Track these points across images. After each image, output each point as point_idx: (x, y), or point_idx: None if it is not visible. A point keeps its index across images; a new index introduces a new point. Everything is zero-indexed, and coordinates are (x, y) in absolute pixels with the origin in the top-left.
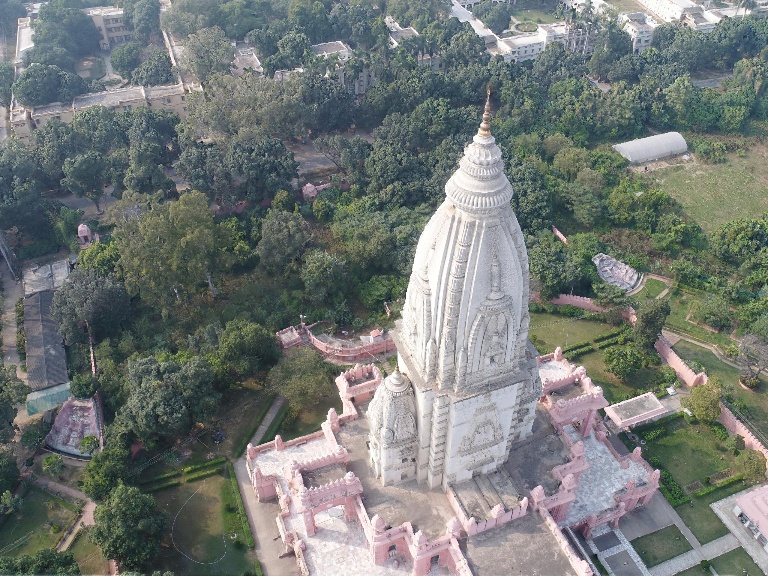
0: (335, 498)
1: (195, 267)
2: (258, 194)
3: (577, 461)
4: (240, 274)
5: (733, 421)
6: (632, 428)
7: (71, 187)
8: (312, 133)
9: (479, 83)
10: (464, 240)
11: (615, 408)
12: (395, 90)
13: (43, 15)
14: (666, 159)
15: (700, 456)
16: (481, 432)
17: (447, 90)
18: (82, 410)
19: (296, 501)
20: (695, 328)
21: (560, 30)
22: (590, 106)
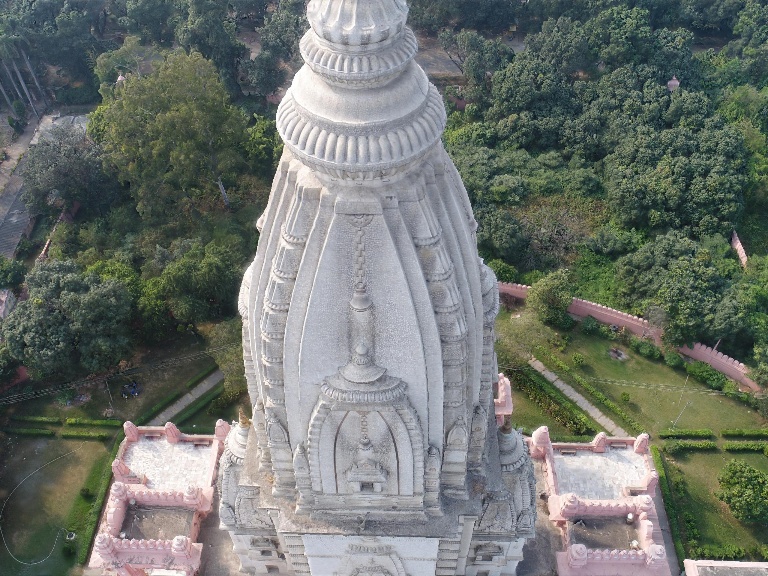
0: None
1: None
2: None
3: None
4: None
5: None
6: None
7: (130, 29)
8: (454, 27)
9: (710, 0)
10: (290, 228)
11: (703, 568)
12: None
13: None
14: None
15: None
16: None
17: (658, 2)
18: None
19: None
20: None
21: None
22: None
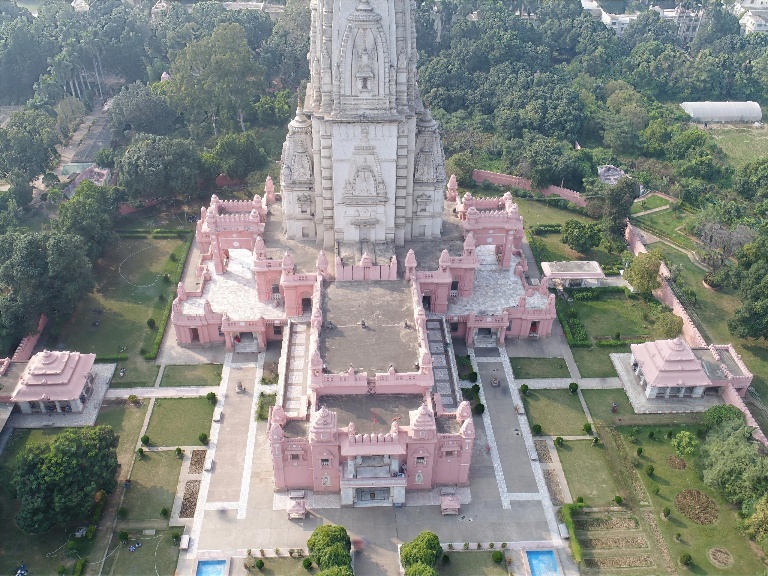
0: (241, 236)
1: (222, 89)
2: None
3: (467, 256)
4: None
5: (671, 299)
6: (564, 286)
7: (169, 47)
8: None
9: (561, 34)
10: None
11: (551, 263)
12: (476, 26)
13: None
14: (734, 123)
15: (623, 321)
16: (362, 178)
17: (527, 35)
18: (99, 176)
19: (205, 225)
20: (681, 237)
21: (671, 14)
22: (666, 65)
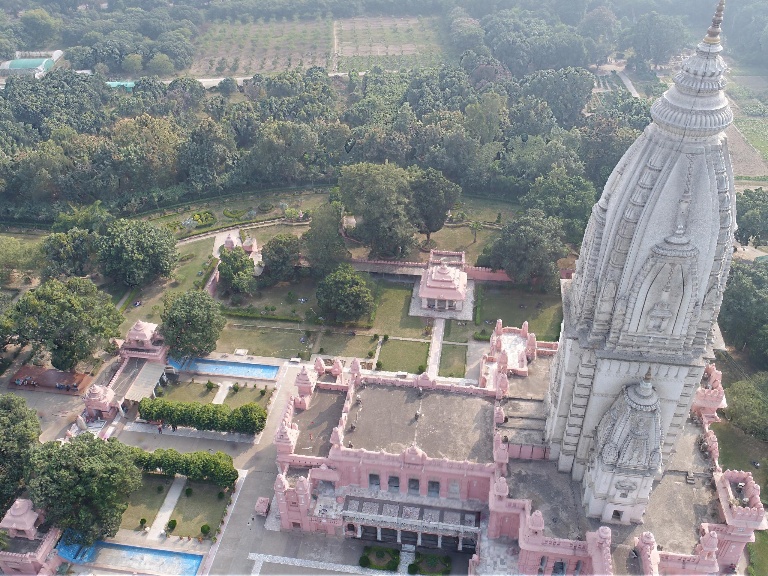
0: None
1: None
2: None
3: None
4: None
5: None
6: None
7: None
8: None
9: None
10: None
11: None
12: None
13: None
14: None
15: None
16: None
17: None
18: None
19: None
20: None
21: None
22: None
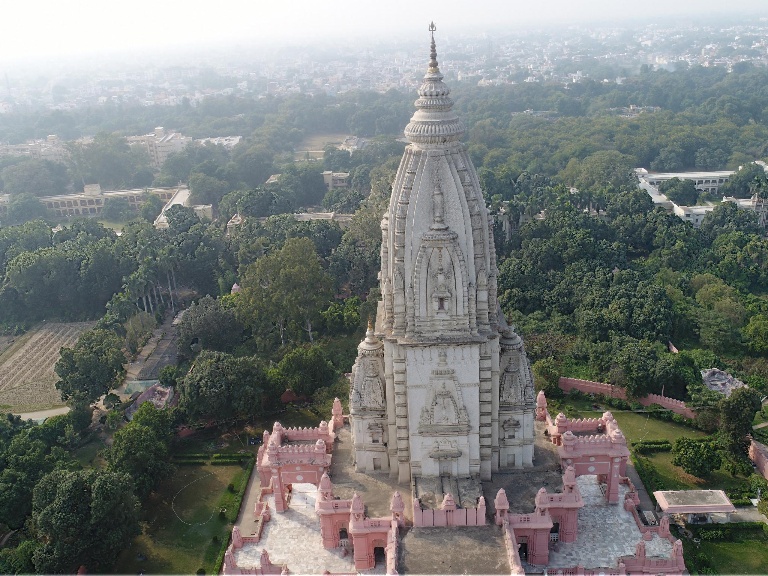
0: (305, 469)
1: (290, 301)
2: None
3: (567, 493)
4: None
5: None
6: (686, 522)
7: (241, 260)
8: None
9: (635, 229)
10: (410, 167)
11: (666, 493)
12: (545, 226)
13: (287, 170)
14: None
15: None
16: (440, 405)
17: (599, 232)
18: (161, 395)
19: (266, 457)
20: None
21: (747, 203)
22: (754, 256)
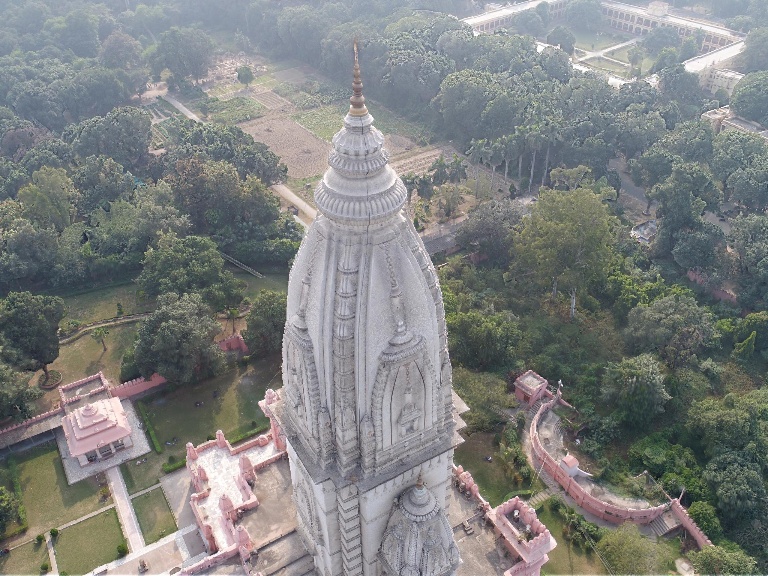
0: None
1: None
2: (752, 299)
3: None
4: (621, 329)
5: None
6: None
7: (633, 170)
8: None
9: None
10: None
11: None
12: None
13: None
14: None
15: None
16: None
17: None
18: None
19: None
20: None
21: None
22: None
